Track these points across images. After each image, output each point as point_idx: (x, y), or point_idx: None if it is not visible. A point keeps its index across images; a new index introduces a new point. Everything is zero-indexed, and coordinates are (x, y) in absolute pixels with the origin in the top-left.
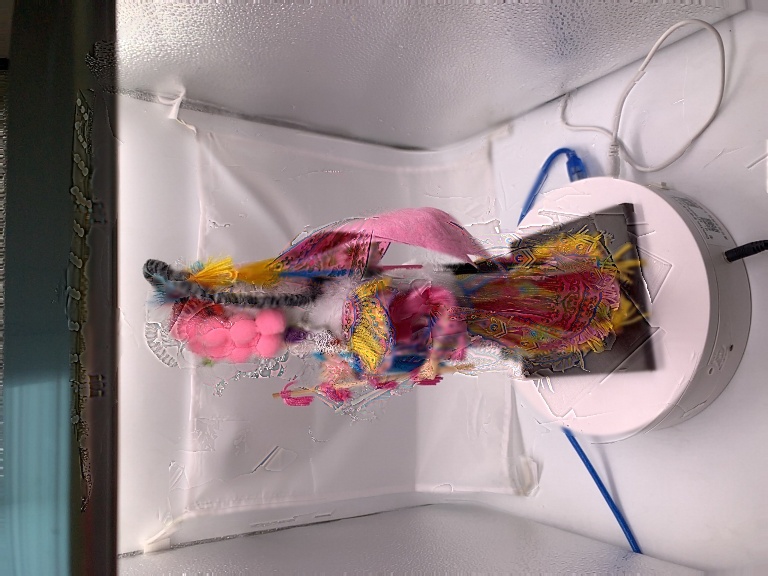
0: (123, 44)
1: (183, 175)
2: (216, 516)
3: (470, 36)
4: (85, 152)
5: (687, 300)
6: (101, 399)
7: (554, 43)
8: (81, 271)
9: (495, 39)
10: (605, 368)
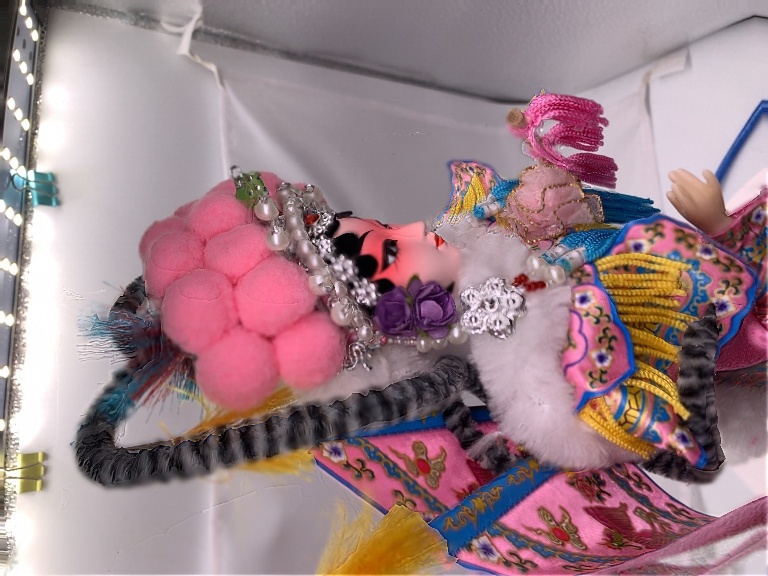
0: None
1: None
2: None
3: None
4: None
5: (729, 207)
6: None
7: None
8: None
9: None
10: None
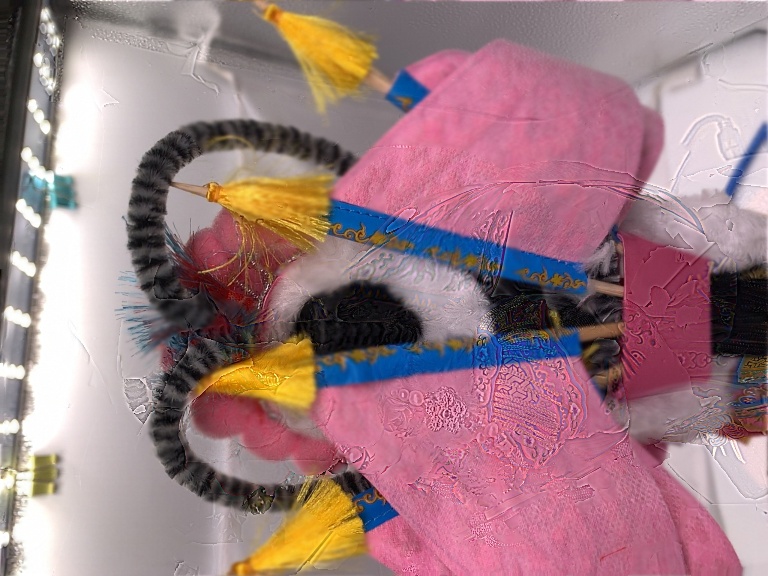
0: None
1: (200, 152)
2: None
3: None
4: (49, 100)
5: None
6: (53, 499)
7: None
8: (34, 281)
9: None
10: None
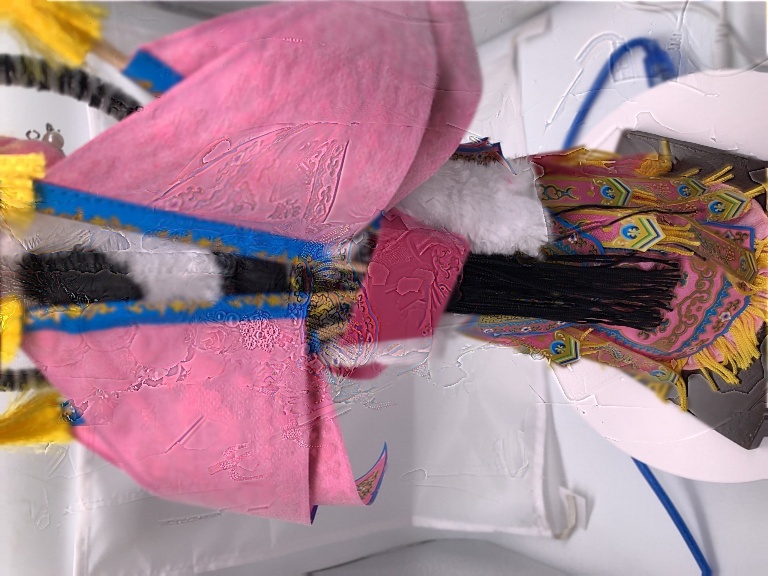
0: None
1: (72, 27)
2: (112, 513)
3: None
4: None
5: None
6: None
7: None
8: None
9: None
10: None
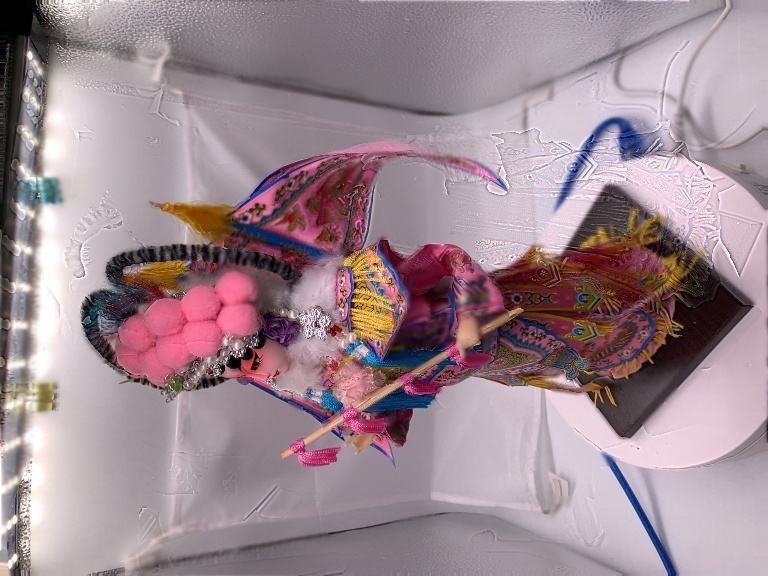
0: (96, 31)
1: (166, 176)
2: None
3: (485, 2)
4: (34, 126)
5: None
6: (29, 413)
7: (582, 6)
8: (19, 260)
9: (514, 5)
10: (683, 366)
